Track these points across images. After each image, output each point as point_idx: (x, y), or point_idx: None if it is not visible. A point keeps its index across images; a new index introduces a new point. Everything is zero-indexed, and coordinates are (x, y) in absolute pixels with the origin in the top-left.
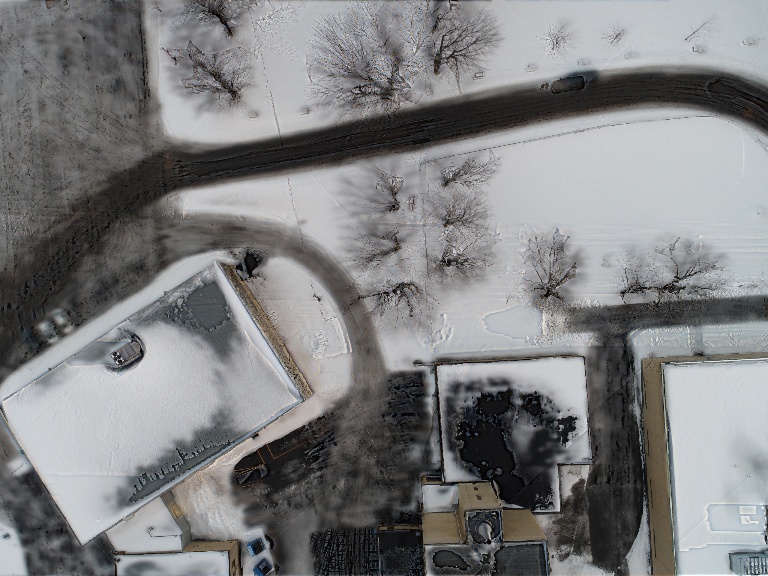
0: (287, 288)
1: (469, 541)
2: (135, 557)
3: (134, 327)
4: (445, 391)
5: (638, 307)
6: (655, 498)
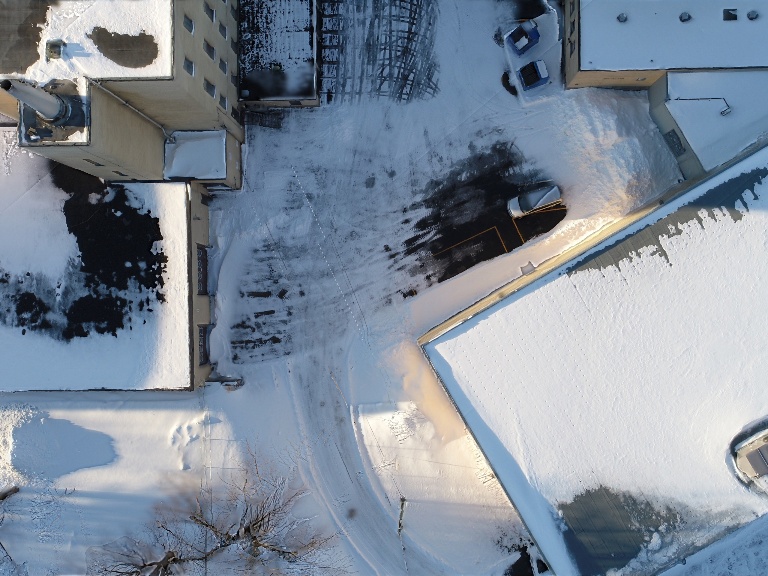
0: (460, 525)
1: (86, 85)
2: (759, 63)
3: (749, 501)
4: (179, 342)
5: None
6: None
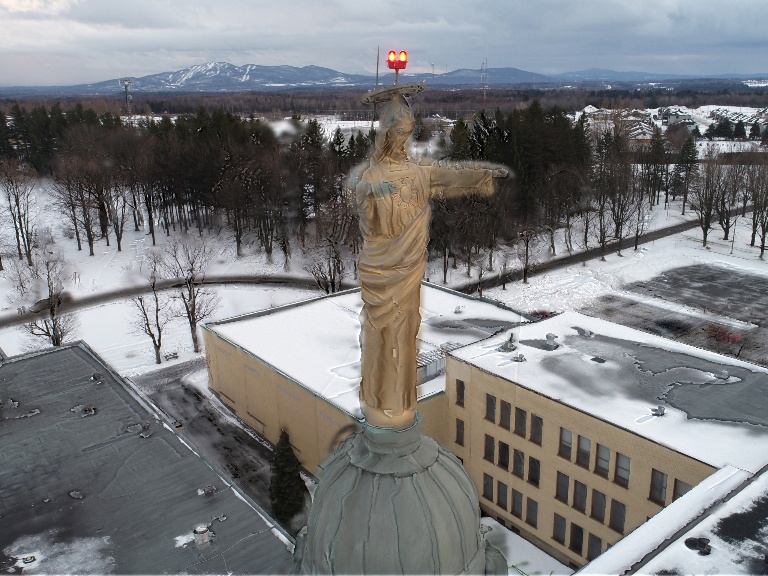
0: None
1: None
2: None
3: None
4: None
5: (181, 366)
6: (291, 434)
